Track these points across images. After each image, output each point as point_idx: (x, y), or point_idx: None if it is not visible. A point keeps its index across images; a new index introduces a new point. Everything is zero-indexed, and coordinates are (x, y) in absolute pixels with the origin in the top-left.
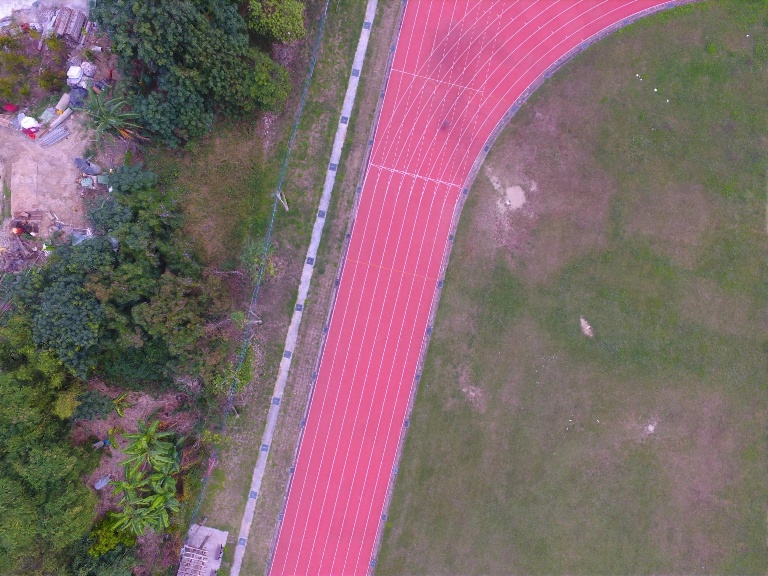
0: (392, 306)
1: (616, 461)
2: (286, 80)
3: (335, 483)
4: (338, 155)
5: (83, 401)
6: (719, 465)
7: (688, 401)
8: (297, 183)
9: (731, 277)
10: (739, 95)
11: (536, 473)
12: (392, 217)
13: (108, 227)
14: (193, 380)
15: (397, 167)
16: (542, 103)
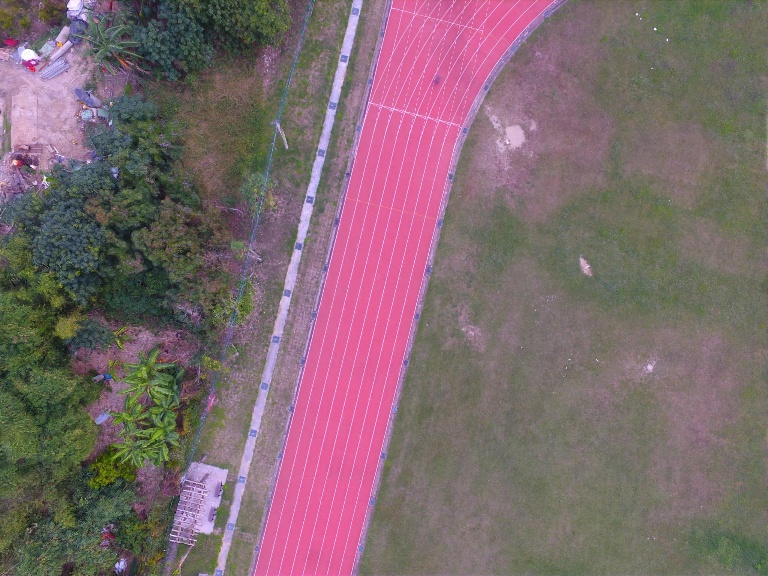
0: (392, 245)
1: (615, 400)
2: (286, 11)
3: (335, 422)
4: (338, 94)
5: (83, 328)
6: (718, 404)
7: (687, 340)
8: (297, 122)
9: (730, 217)
10: (739, 34)
11: (535, 412)
12: (392, 156)
13: (108, 152)
14: (193, 308)
15: (397, 106)
16: (542, 42)
